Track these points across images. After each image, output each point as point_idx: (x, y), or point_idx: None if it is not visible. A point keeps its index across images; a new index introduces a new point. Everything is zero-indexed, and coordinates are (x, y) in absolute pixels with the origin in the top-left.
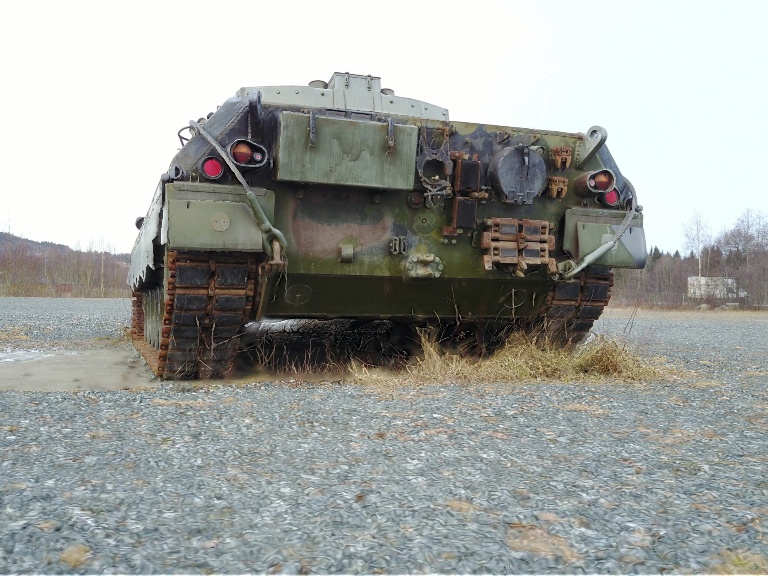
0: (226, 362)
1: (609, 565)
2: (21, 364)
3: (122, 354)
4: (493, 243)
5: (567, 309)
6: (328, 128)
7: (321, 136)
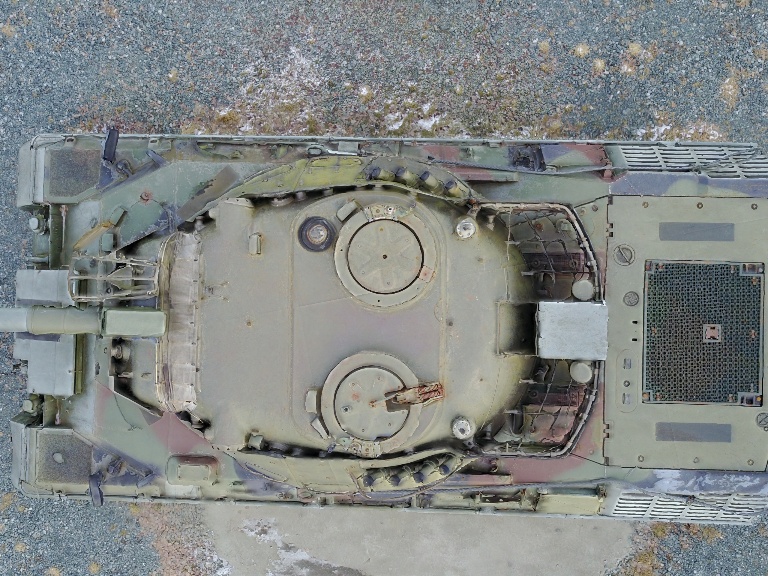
0: None
1: None
2: (402, 574)
3: None
4: None
5: None
6: None
7: None
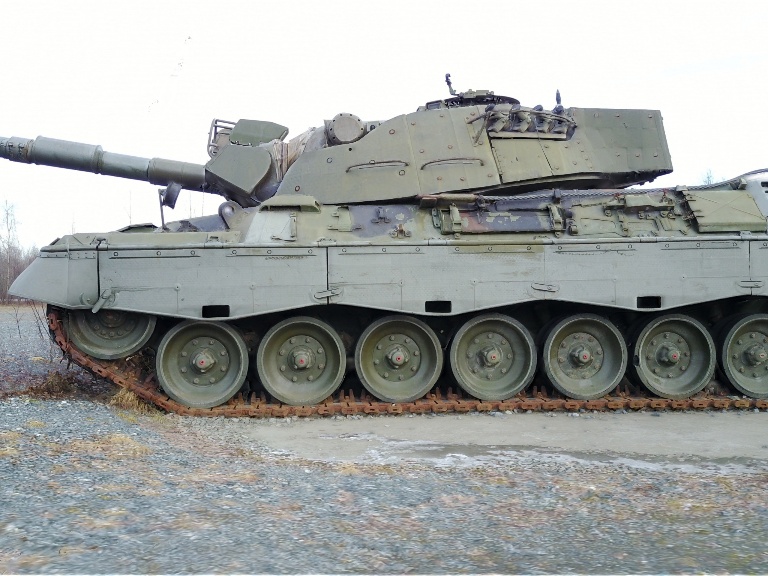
0: None
1: None
2: (611, 444)
3: (398, 421)
4: None
5: None
6: None
7: None
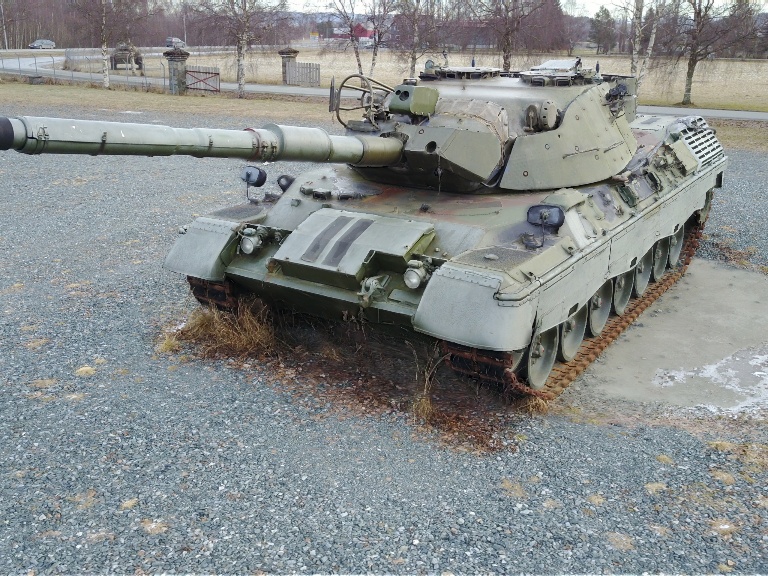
0: None
1: (720, 199)
2: (753, 335)
3: (628, 351)
4: None
5: None
6: None
7: None
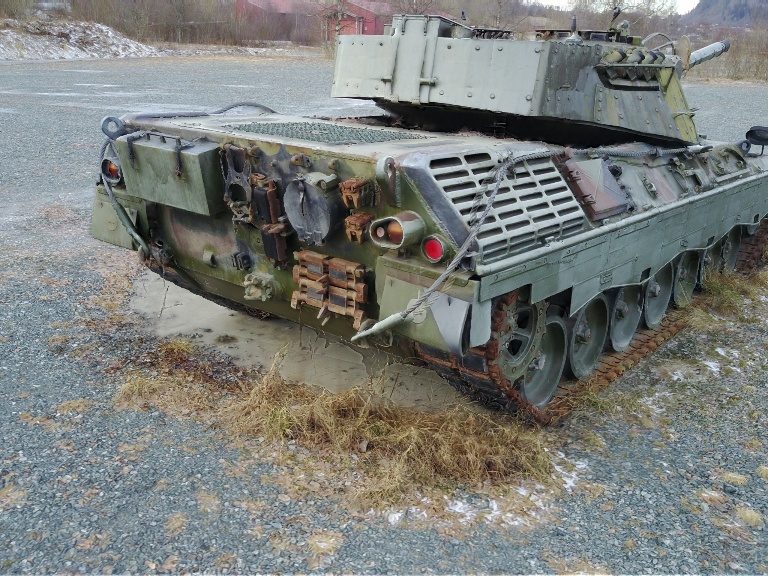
0: (246, 312)
1: None
2: None
3: None
4: (302, 279)
5: (442, 368)
6: (143, 153)
7: (141, 160)
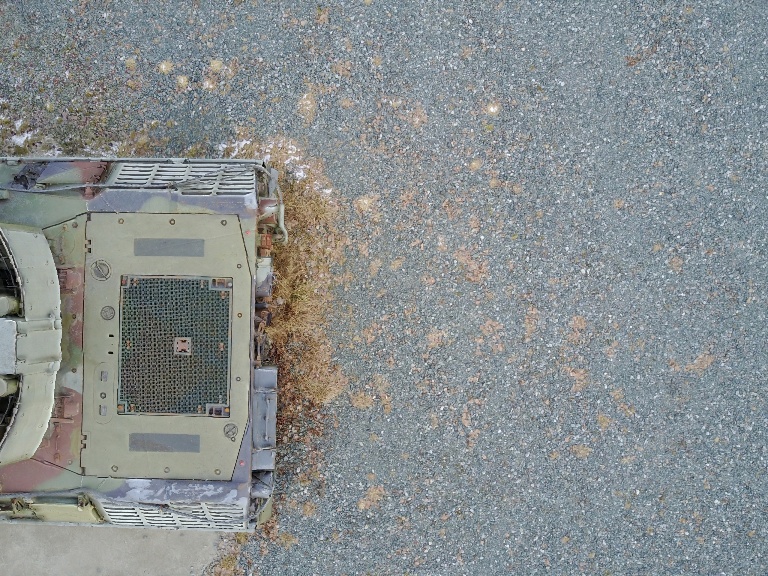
0: None
1: None
2: None
3: None
4: None
5: None
6: None
7: None
